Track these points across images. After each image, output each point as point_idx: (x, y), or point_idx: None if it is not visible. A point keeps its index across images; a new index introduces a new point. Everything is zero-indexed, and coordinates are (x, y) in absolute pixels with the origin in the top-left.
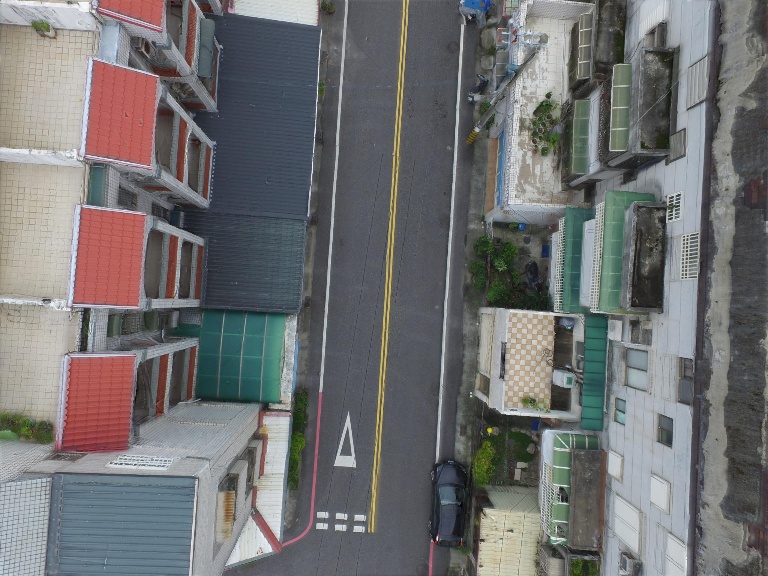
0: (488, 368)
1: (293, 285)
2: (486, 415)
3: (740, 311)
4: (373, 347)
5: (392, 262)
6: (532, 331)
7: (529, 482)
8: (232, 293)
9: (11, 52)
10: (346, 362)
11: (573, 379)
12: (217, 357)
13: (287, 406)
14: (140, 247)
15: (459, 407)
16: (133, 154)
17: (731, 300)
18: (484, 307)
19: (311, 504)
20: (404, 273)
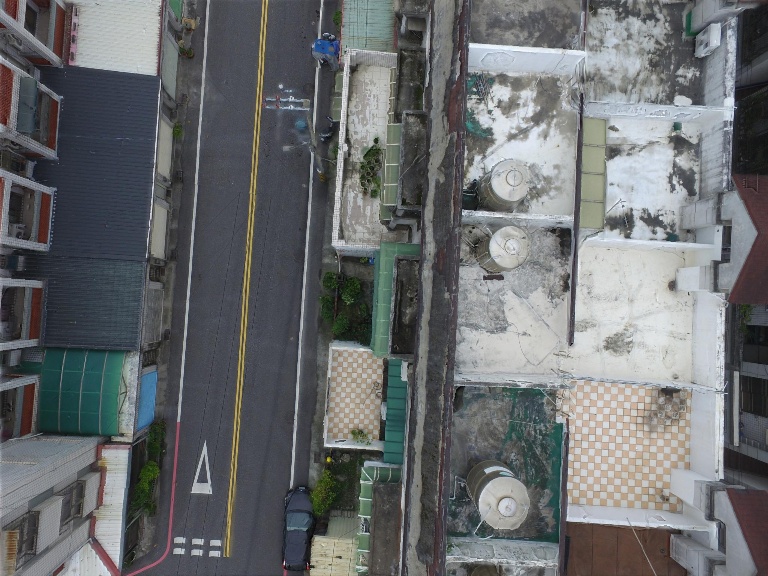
0: None
1: (131, 323)
2: None
3: (431, 368)
4: (230, 378)
5: (248, 296)
6: (362, 365)
7: None
8: (71, 332)
9: None
10: (204, 392)
11: None
12: (57, 393)
13: (129, 439)
14: None
15: (313, 435)
16: None
17: (428, 357)
18: (332, 339)
19: (168, 530)
20: (260, 306)
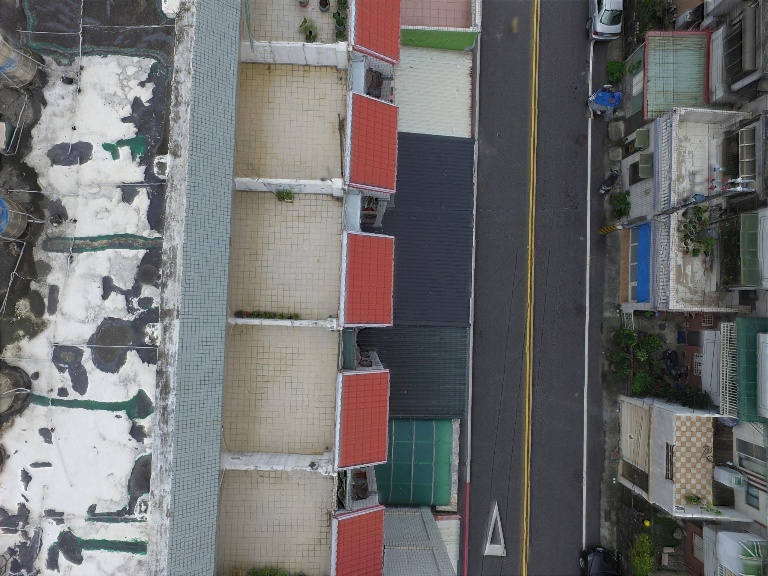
0: (639, 460)
1: (459, 391)
2: (630, 501)
3: None
4: (517, 436)
5: (532, 353)
6: (691, 428)
7: (677, 566)
8: (402, 402)
9: (252, 217)
10: (491, 452)
11: (741, 479)
12: (389, 465)
13: (453, 508)
14: (385, 403)
15: (603, 493)
16: (378, 316)
17: None
18: (628, 397)
19: None
20: (544, 363)
